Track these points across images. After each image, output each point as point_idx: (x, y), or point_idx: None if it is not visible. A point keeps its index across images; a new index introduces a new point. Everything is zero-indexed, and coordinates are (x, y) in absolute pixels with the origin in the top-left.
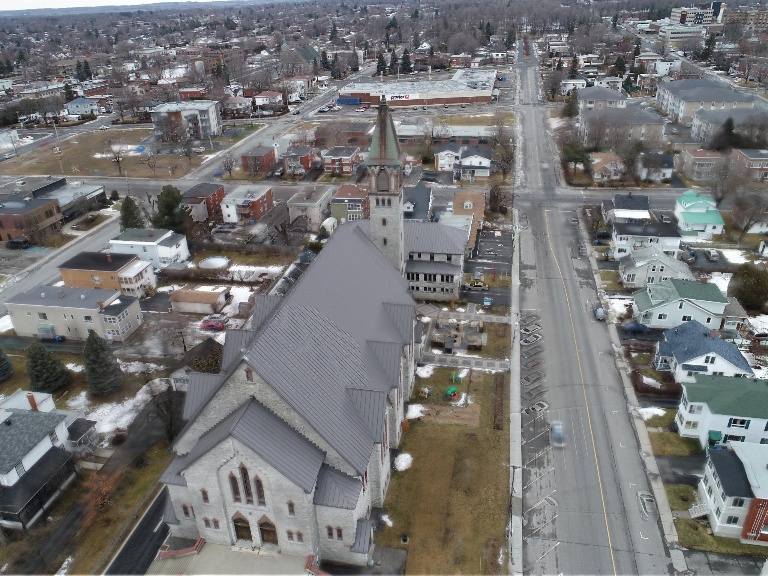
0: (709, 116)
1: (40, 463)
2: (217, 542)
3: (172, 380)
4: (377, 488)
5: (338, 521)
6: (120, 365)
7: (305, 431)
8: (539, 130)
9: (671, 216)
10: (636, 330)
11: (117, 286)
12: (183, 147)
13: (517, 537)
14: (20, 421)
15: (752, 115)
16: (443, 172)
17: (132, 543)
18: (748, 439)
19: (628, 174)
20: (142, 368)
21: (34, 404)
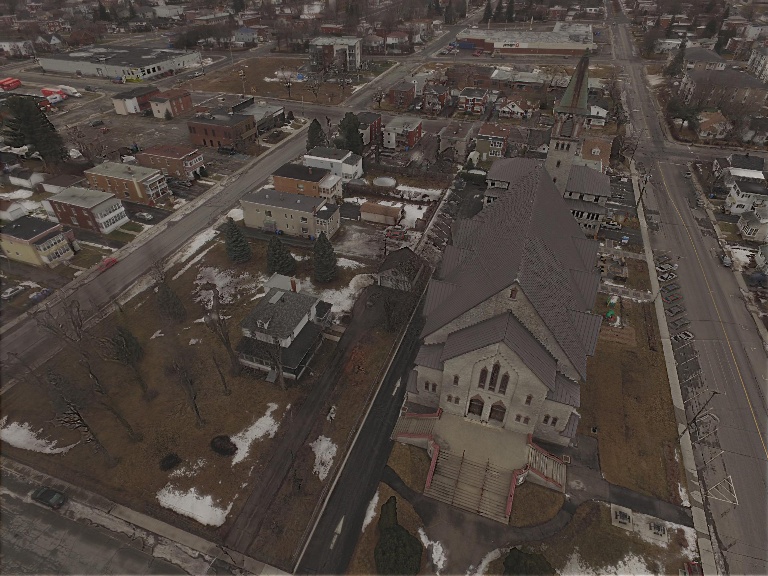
0: None
1: (303, 332)
2: (452, 412)
3: (379, 277)
4: None
5: (558, 413)
6: None
7: (546, 342)
8: (639, 85)
9: None
10: (762, 279)
11: (316, 194)
12: (340, 78)
13: (687, 441)
14: (289, 300)
15: None
16: None
17: (379, 402)
18: None
19: (736, 135)
20: (348, 264)
21: (295, 287)
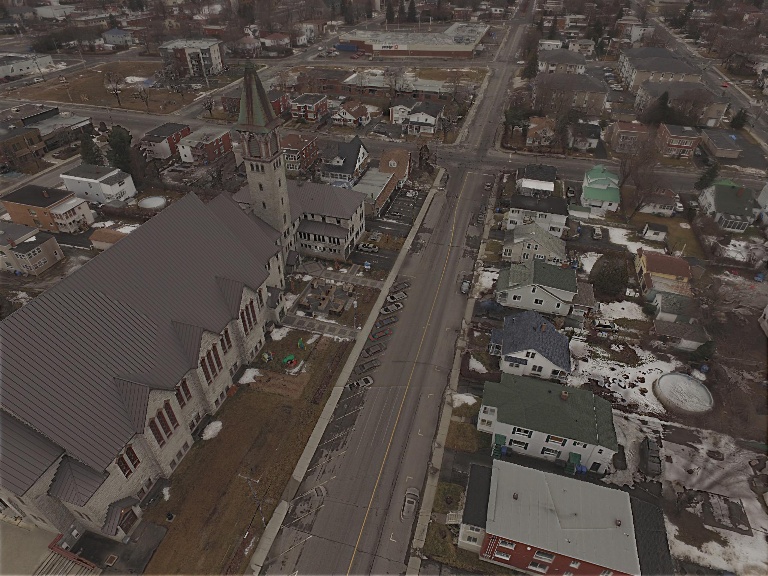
0: (651, 88)
1: None
2: None
3: None
4: (157, 465)
5: (80, 509)
6: (22, 300)
7: None
8: (501, 89)
9: (579, 188)
10: (490, 308)
11: (51, 220)
12: (174, 84)
13: (275, 525)
14: None
15: (689, 91)
16: (396, 125)
17: None
18: (531, 446)
19: (555, 142)
20: None
21: None
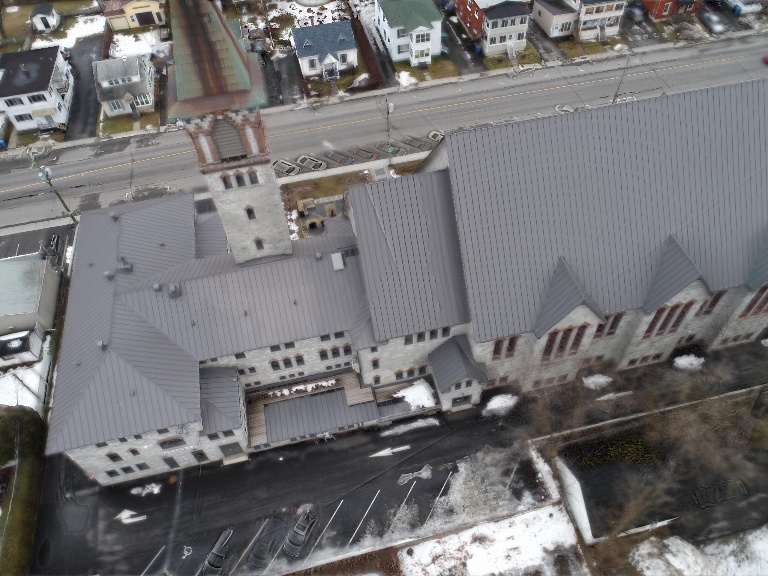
0: None
1: None
2: None
3: None
4: None
5: None
6: None
7: None
8: None
9: None
10: None
11: None
12: None
13: None
14: None
15: None
16: None
17: None
18: None
19: None
20: None
21: None
